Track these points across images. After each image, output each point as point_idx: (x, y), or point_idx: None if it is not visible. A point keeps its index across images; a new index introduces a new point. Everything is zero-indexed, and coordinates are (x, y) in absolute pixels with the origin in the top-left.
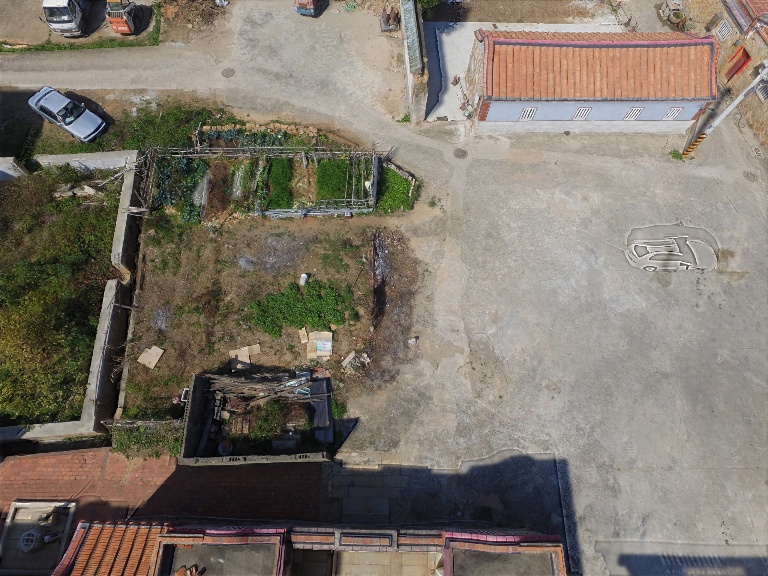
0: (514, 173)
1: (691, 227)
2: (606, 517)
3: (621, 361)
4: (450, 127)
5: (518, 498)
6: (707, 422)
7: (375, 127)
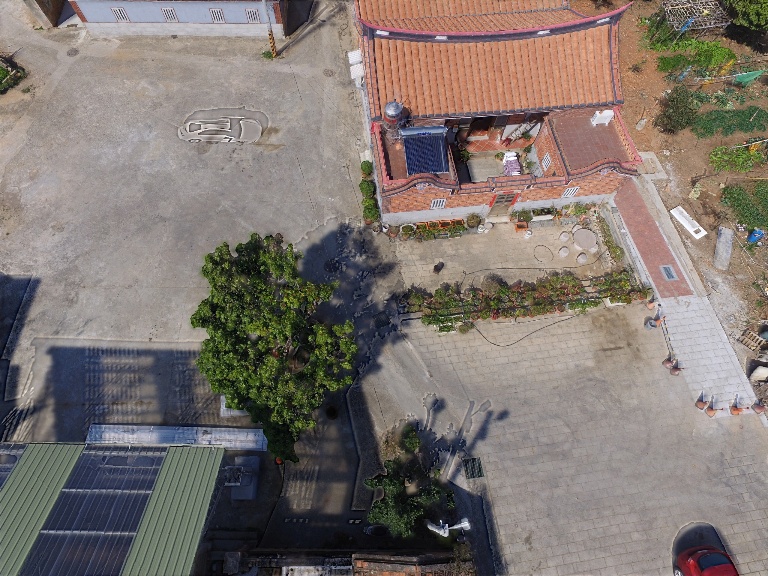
0: (111, 67)
1: (251, 110)
2: (53, 321)
3: (130, 209)
4: (74, 32)
5: None
6: (182, 254)
7: (13, 34)
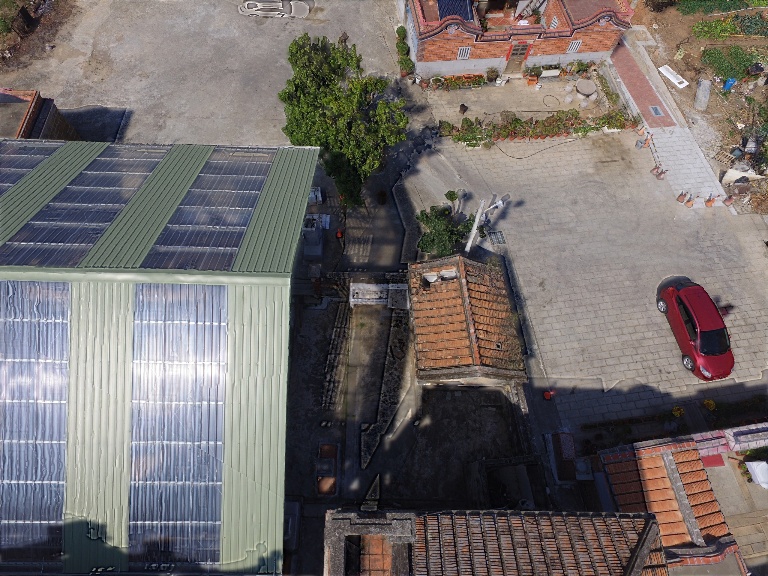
0: None
1: None
2: (147, 140)
3: (203, 63)
4: None
5: (88, 129)
6: (249, 96)
7: None
